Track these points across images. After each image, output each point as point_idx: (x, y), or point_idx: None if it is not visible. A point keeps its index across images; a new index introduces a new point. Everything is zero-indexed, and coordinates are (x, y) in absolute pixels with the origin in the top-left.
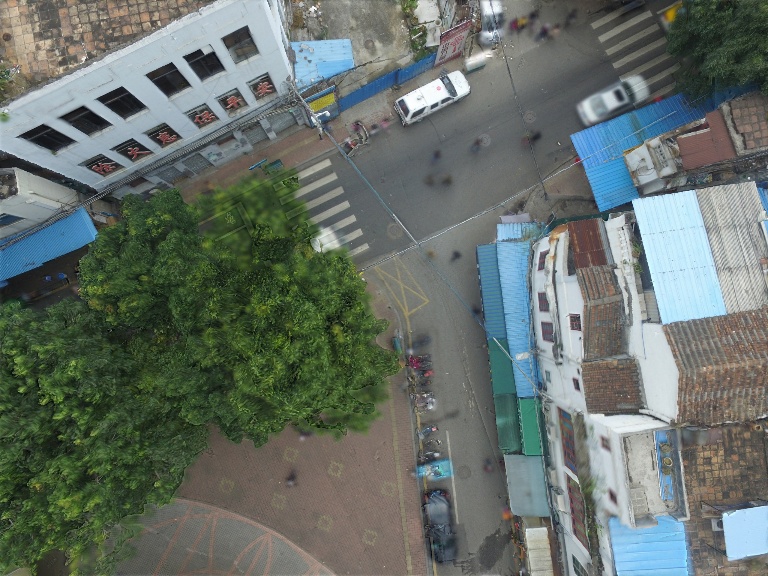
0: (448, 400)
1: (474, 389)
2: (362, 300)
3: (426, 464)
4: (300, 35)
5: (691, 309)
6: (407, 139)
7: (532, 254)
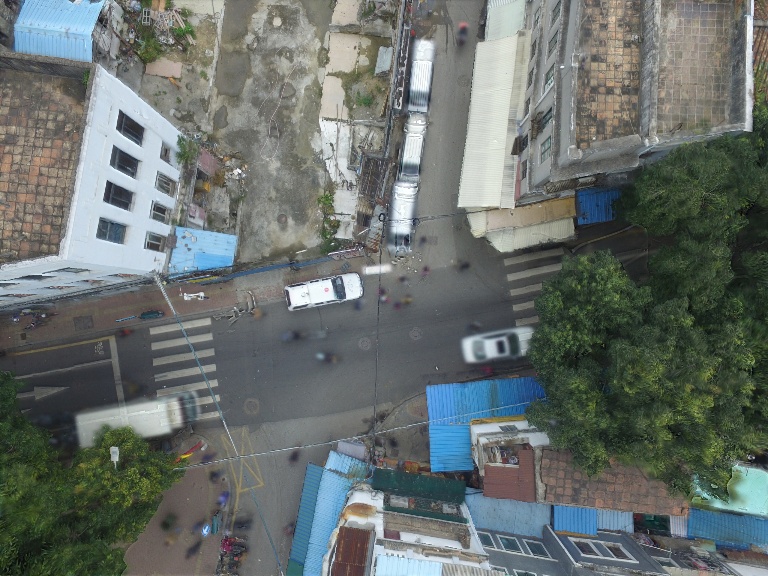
0: None
1: None
2: None
3: None
4: (217, 193)
5: None
6: (291, 320)
7: (348, 497)
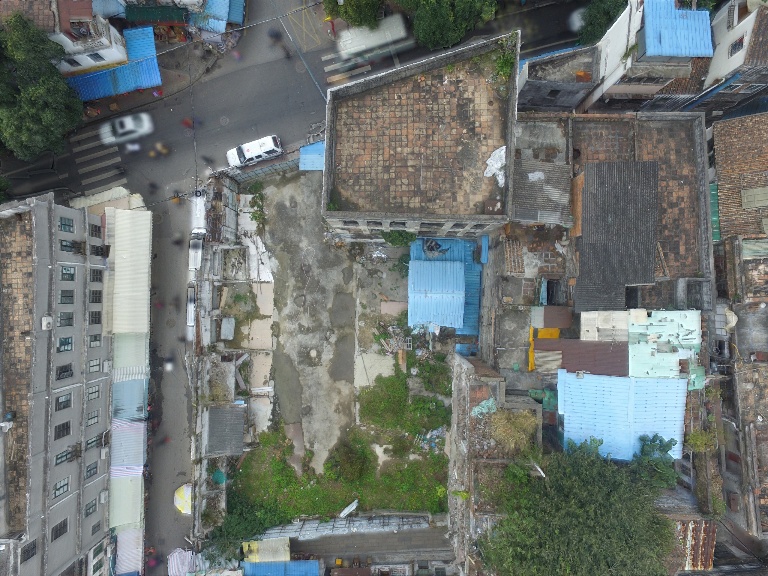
0: None
1: None
2: None
3: None
4: None
5: None
6: (280, 131)
7: (204, 1)
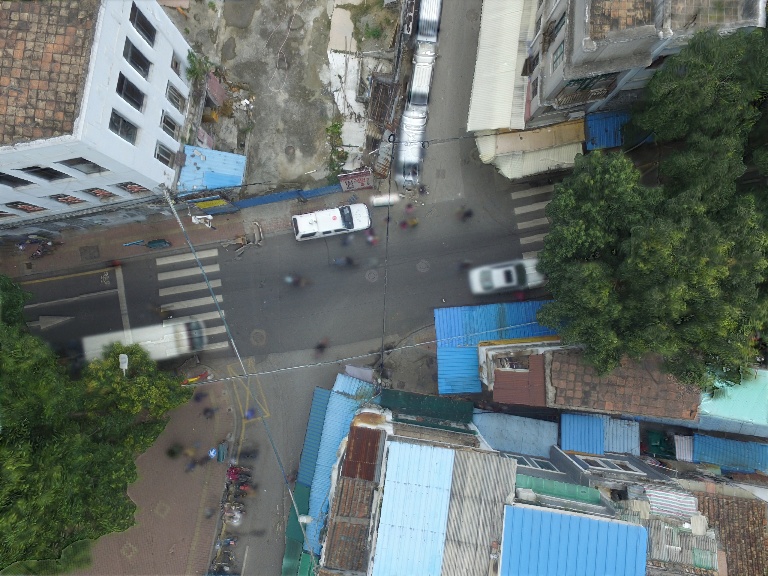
0: (258, 517)
1: (286, 514)
2: (206, 395)
3: (217, 572)
4: (225, 123)
5: (405, 572)
6: (298, 252)
7: None
